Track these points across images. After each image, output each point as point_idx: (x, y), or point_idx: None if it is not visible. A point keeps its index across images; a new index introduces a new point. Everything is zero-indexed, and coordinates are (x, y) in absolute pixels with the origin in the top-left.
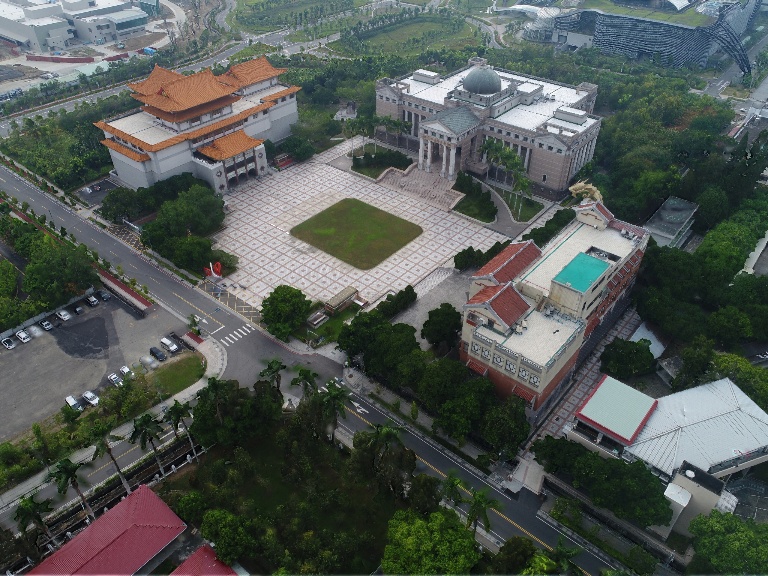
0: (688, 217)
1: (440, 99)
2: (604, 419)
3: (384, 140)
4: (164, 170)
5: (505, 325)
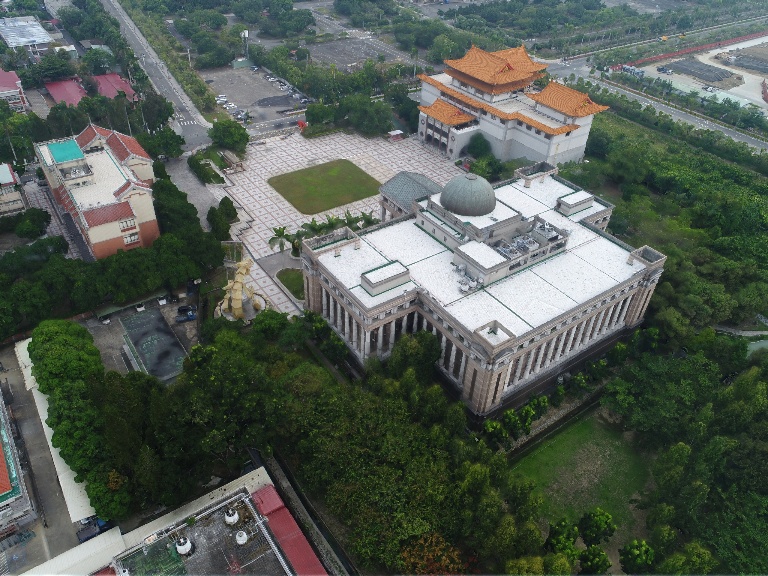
0: None
1: None
2: None
3: None
4: (424, 98)
5: (77, 136)
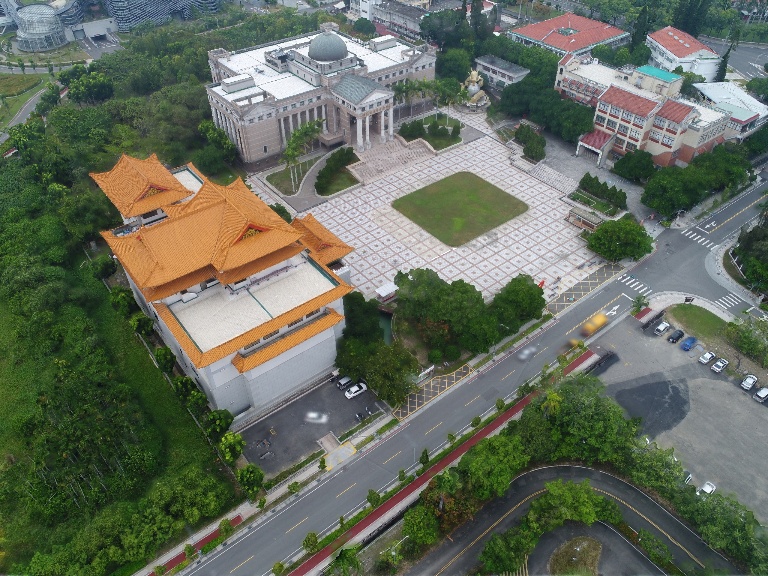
0: (506, 61)
1: (300, 87)
2: (746, 116)
3: (264, 168)
4: None
5: None
